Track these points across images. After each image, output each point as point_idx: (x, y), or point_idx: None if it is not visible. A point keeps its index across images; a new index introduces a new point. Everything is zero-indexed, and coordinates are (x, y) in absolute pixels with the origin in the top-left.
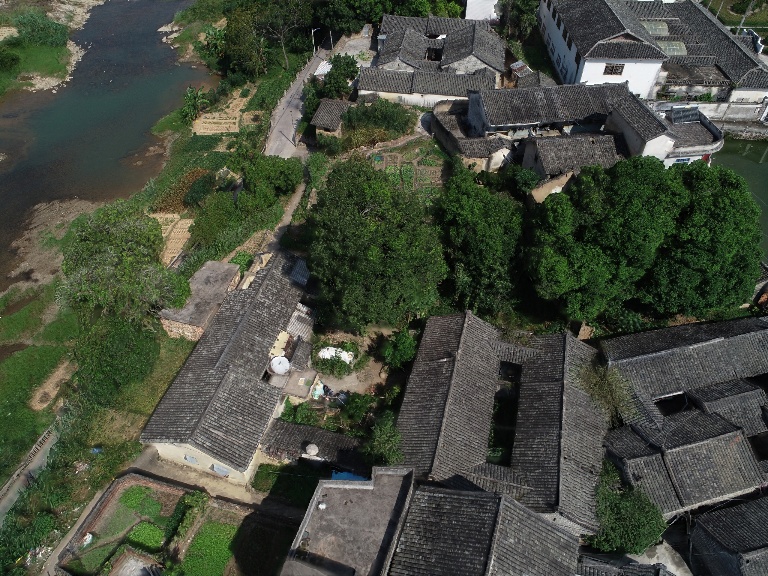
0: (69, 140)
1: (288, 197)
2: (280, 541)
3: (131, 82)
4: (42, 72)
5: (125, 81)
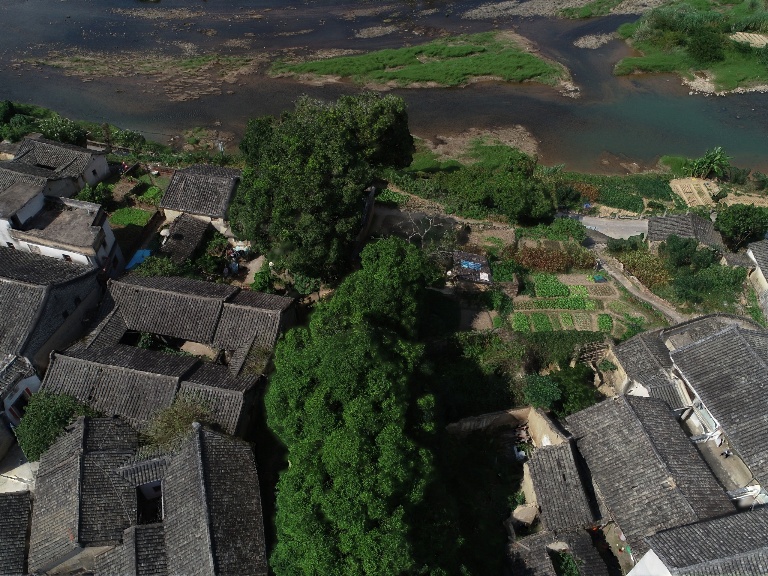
0: (619, 119)
1: (508, 221)
2: (127, 244)
3: (748, 129)
4: (717, 78)
5: (747, 125)
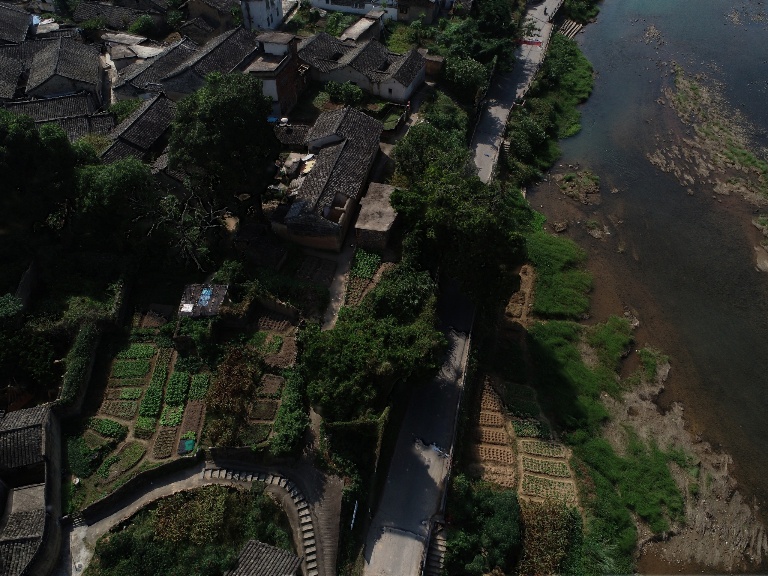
0: None
1: None
2: None
3: None
4: None
5: None
